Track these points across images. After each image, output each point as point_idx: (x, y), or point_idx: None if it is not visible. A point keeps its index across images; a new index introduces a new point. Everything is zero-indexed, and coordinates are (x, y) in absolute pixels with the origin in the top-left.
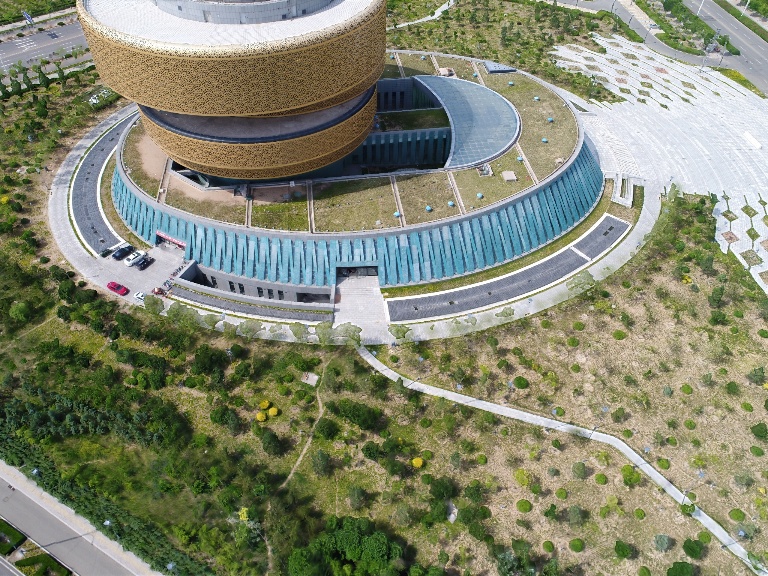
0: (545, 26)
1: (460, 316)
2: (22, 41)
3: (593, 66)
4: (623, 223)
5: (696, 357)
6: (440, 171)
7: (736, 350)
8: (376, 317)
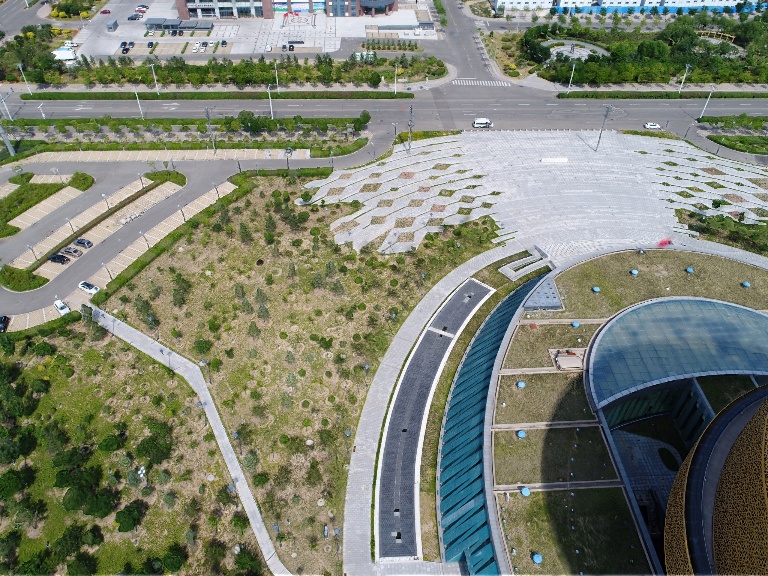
0: None
1: None
2: None
3: (400, 221)
4: None
5: None
6: None
7: None
8: None
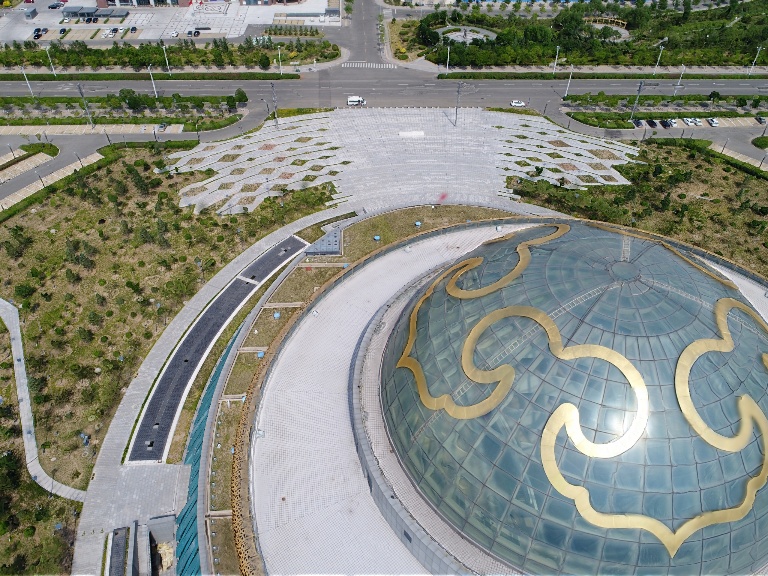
0: (119, 201)
1: None
2: None
3: (246, 187)
4: None
5: (725, 233)
6: None
7: (705, 213)
8: None
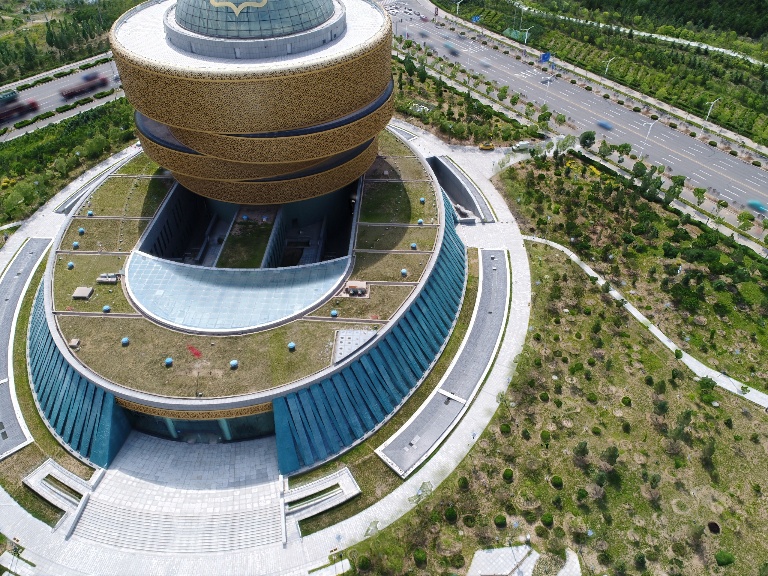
0: None
1: (1, 277)
2: (533, 71)
3: None
4: (1, 452)
5: None
6: (135, 248)
7: None
8: (42, 232)
